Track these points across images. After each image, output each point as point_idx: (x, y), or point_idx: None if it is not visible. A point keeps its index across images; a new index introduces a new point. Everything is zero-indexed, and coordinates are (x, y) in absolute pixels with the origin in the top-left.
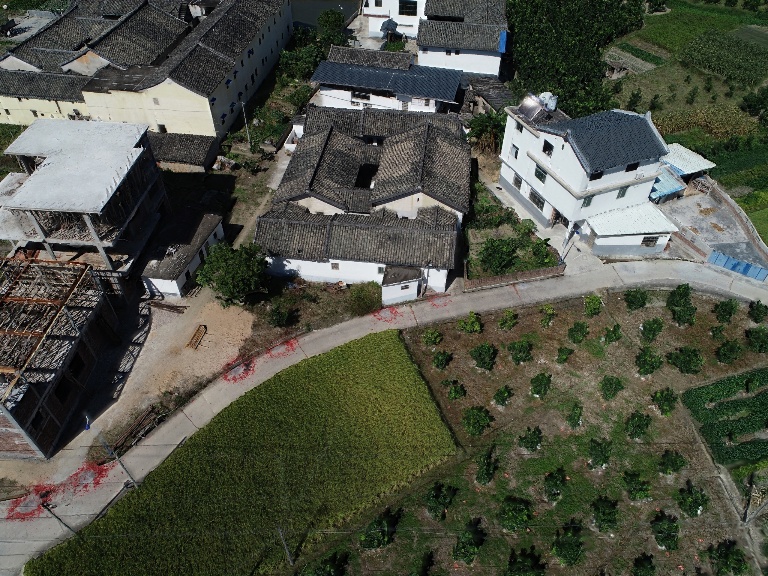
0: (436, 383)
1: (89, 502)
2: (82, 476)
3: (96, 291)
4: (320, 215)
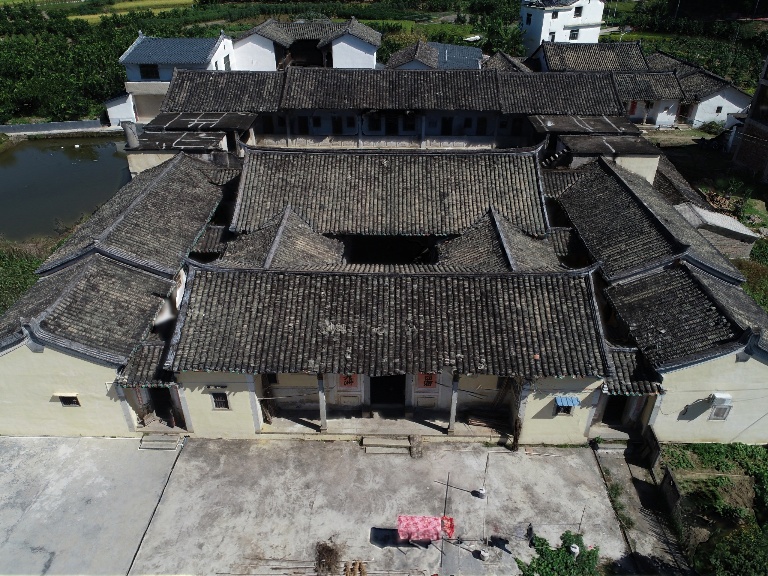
0: None
1: None
2: None
3: None
4: None
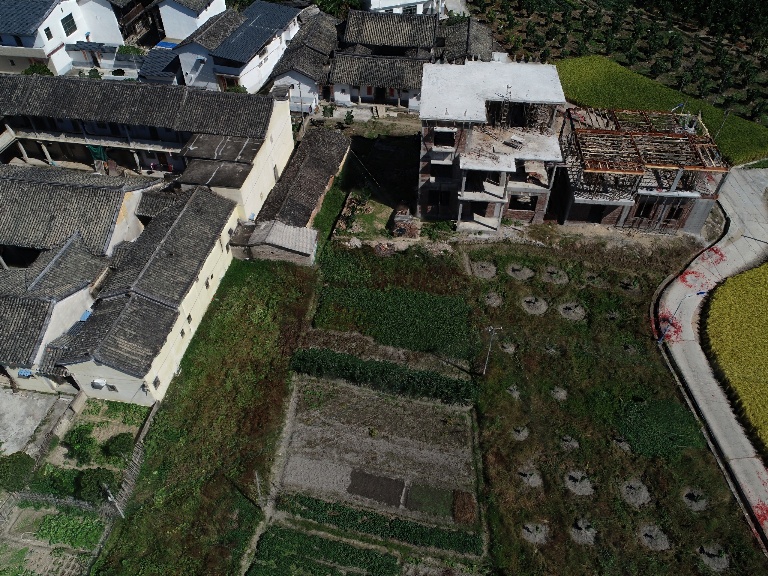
0: None
1: None
2: None
3: (562, 137)
4: None
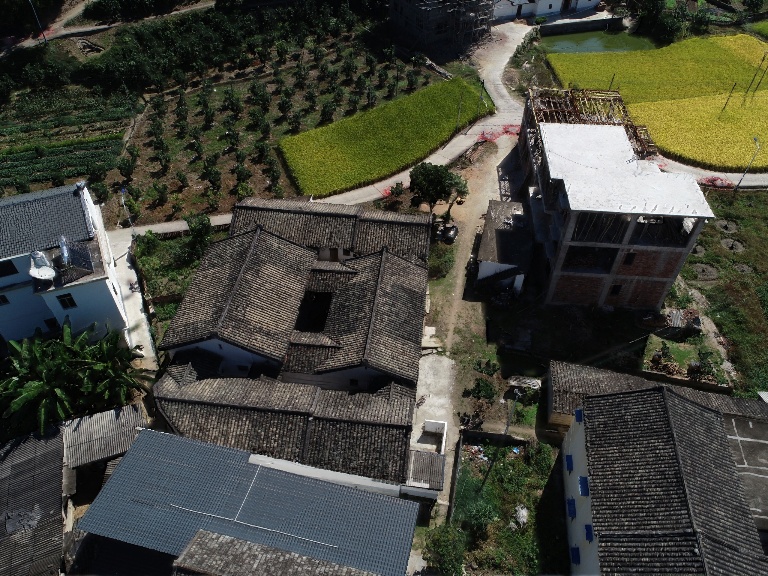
0: (281, 175)
1: (481, 129)
2: (493, 137)
3: None
4: (371, 250)
